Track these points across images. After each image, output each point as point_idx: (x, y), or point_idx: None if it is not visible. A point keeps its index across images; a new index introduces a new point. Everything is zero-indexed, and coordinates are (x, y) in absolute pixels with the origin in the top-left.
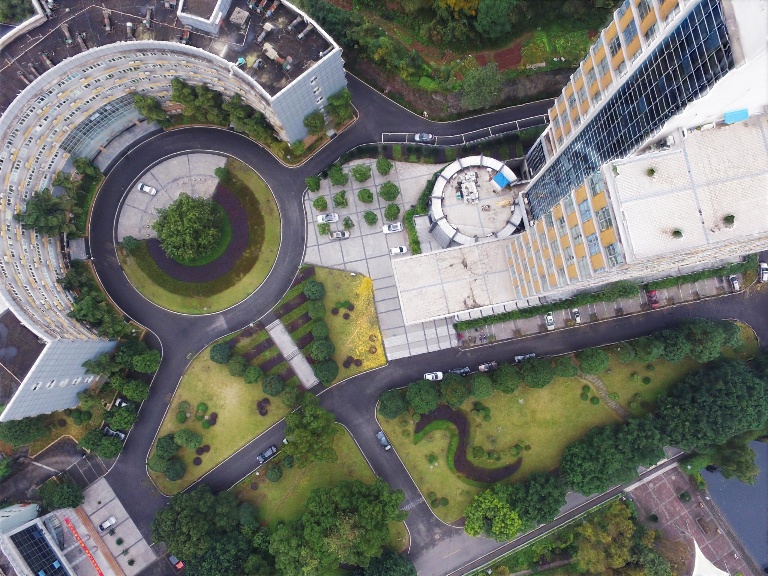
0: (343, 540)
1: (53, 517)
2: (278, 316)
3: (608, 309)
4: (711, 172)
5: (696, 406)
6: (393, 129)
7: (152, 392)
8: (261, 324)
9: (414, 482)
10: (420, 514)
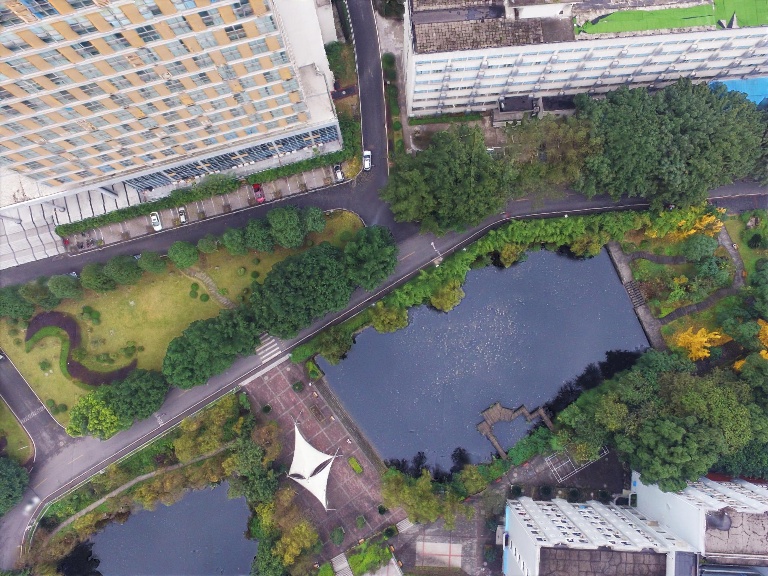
0: None
1: None
2: None
3: (216, 206)
4: None
5: (271, 289)
6: None
7: None
8: None
9: (33, 391)
10: (42, 422)
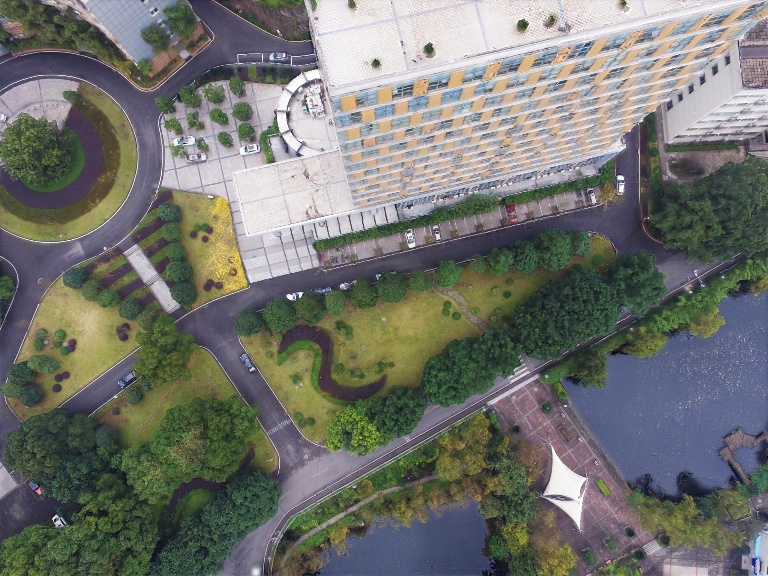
0: (188, 451)
1: None
2: (135, 241)
3: (469, 226)
4: (413, 3)
5: (545, 312)
6: (248, 50)
7: (9, 321)
8: (119, 249)
9: (281, 403)
10: (288, 435)
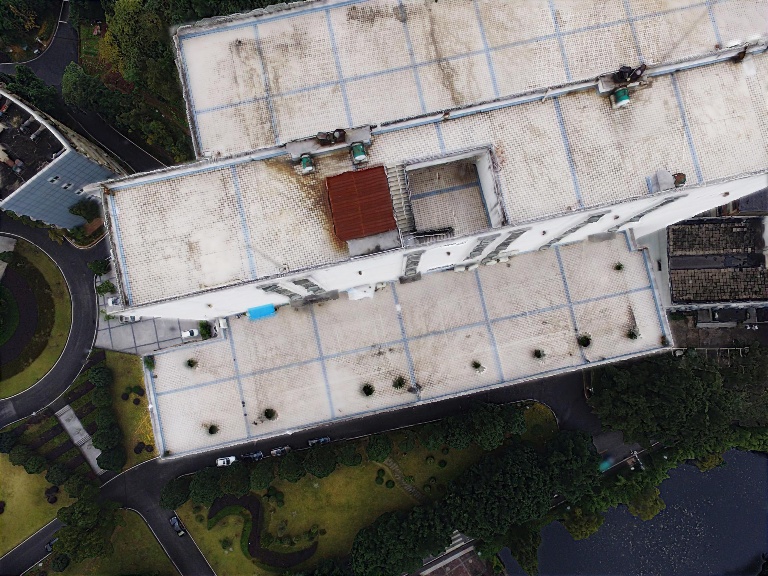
0: None
1: None
2: (67, 402)
3: None
4: (257, 360)
5: (474, 497)
6: None
7: None
8: (50, 410)
9: (211, 566)
10: None
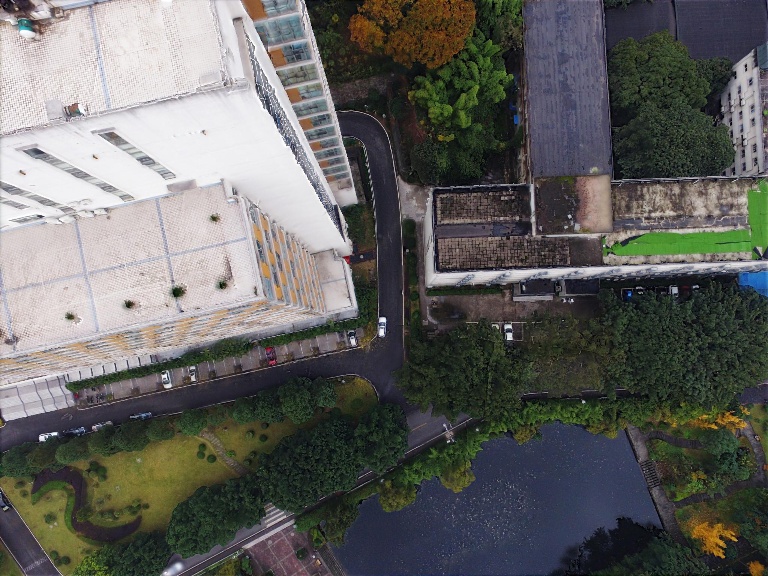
0: None
1: None
2: None
3: (227, 366)
4: None
5: (279, 470)
6: None
7: None
8: None
9: (37, 541)
10: (45, 572)
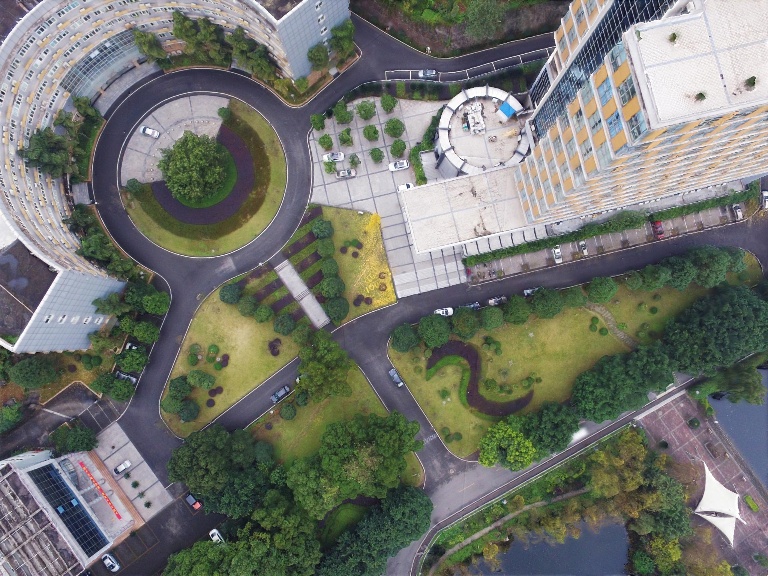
0: (361, 468)
1: (67, 462)
2: (287, 256)
3: (614, 241)
4: (731, 36)
5: (704, 329)
6: (396, 66)
7: (162, 336)
8: (270, 265)
9: (427, 418)
10: (434, 450)
